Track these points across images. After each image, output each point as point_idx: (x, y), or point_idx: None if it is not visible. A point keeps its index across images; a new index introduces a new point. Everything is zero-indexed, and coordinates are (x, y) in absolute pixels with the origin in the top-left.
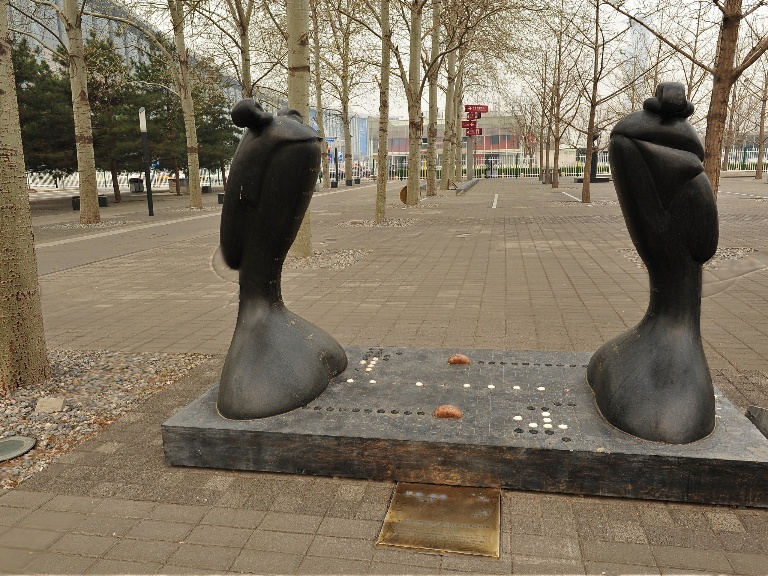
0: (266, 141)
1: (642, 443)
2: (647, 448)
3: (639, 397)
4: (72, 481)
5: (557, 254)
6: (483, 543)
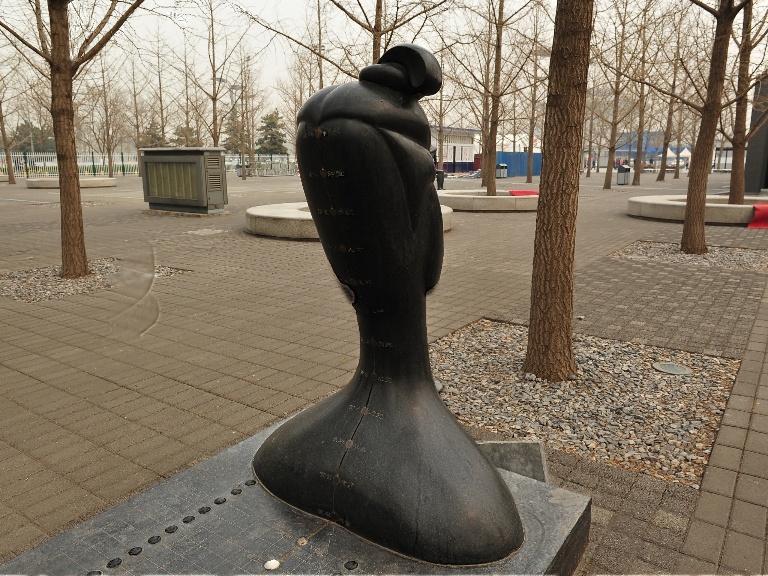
0: None
1: (506, 569)
2: (521, 573)
3: (459, 505)
4: None
5: None
6: None
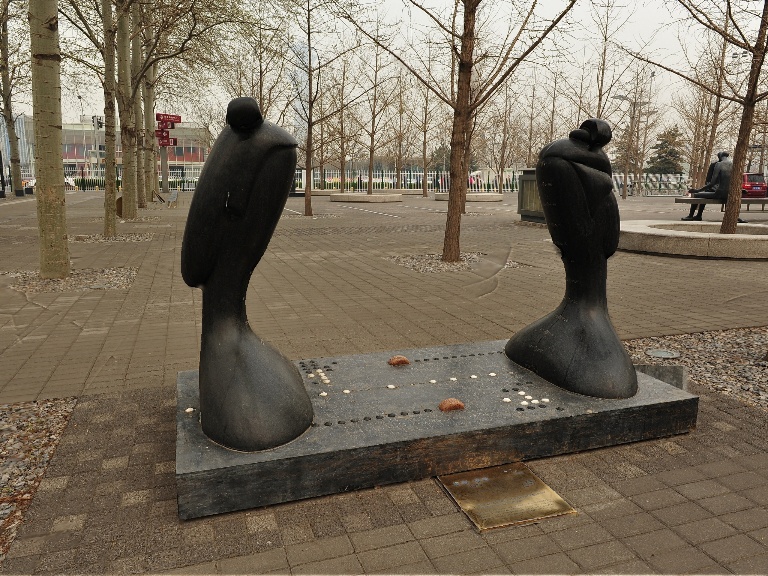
0: (260, 144)
1: (608, 401)
2: (615, 404)
3: (592, 367)
4: (66, 572)
5: (336, 263)
6: (554, 505)
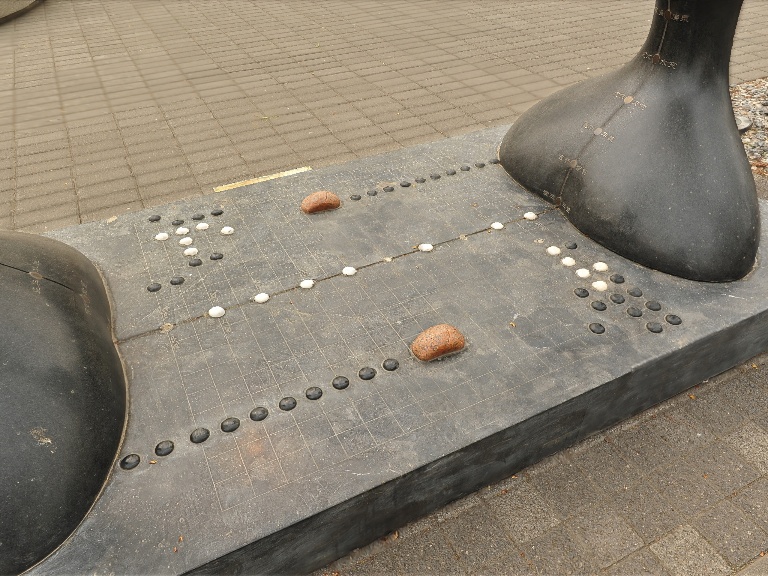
0: None
1: None
2: None
3: None
4: None
5: None
6: None
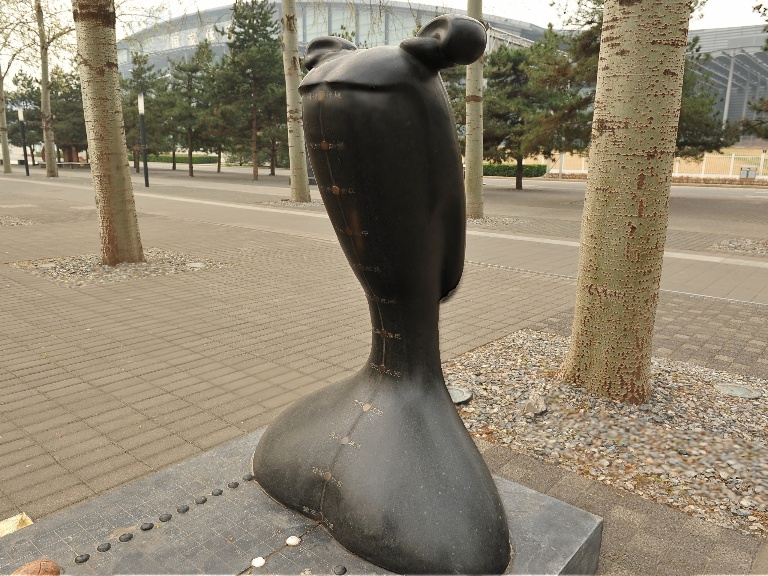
0: None
1: None
2: None
3: None
4: None
5: None
6: None
